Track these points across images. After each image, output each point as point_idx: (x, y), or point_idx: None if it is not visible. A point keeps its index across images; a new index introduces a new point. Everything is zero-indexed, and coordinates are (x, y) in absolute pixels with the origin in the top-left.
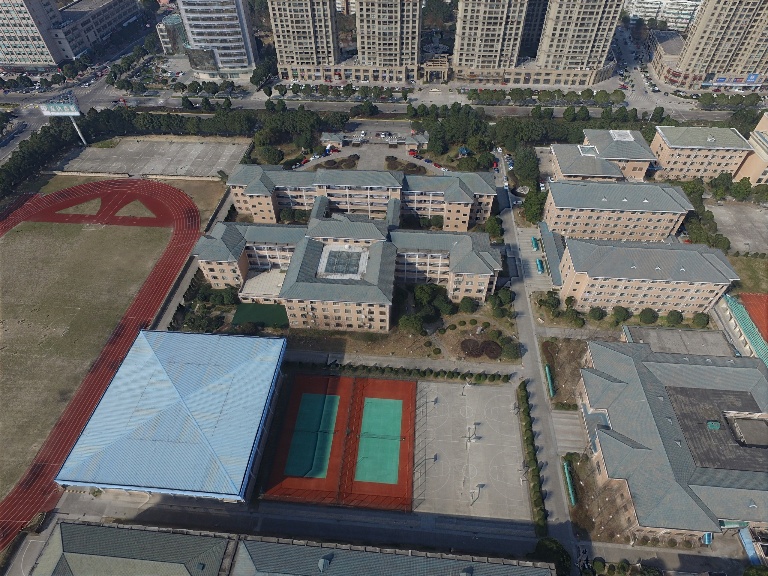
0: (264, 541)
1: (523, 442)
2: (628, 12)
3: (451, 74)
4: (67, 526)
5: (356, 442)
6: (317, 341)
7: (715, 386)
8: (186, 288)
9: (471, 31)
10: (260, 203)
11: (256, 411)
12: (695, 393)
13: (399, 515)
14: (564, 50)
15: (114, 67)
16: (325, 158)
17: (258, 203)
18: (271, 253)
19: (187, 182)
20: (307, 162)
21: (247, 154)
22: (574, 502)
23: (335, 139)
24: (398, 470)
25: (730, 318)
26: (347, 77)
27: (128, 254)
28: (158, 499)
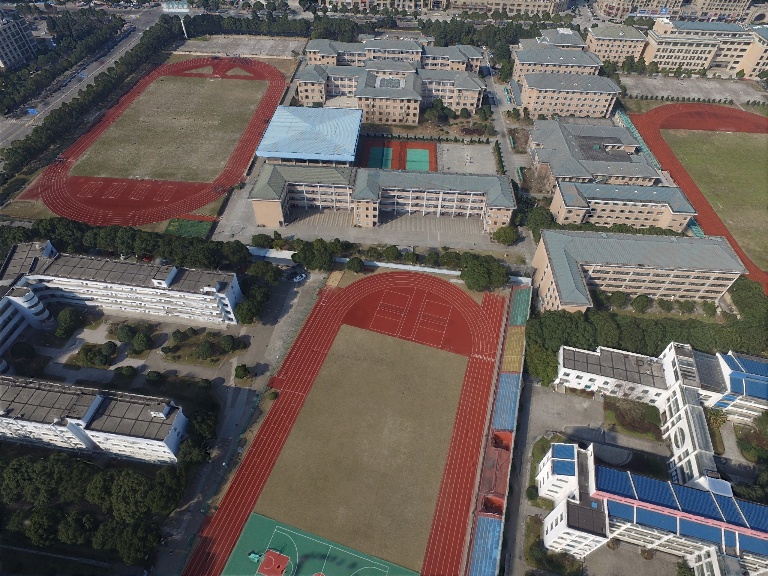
0: None
1: (497, 164)
2: None
3: (448, 4)
4: None
5: (405, 163)
6: (375, 128)
7: (601, 135)
8: None
9: None
10: (328, 63)
11: (354, 132)
12: (590, 138)
13: None
14: None
15: None
16: None
17: (327, 63)
18: (342, 83)
19: (269, 59)
20: None
21: None
22: (522, 181)
23: (369, 37)
24: None
25: (619, 122)
26: (370, 5)
27: (243, 92)
28: None
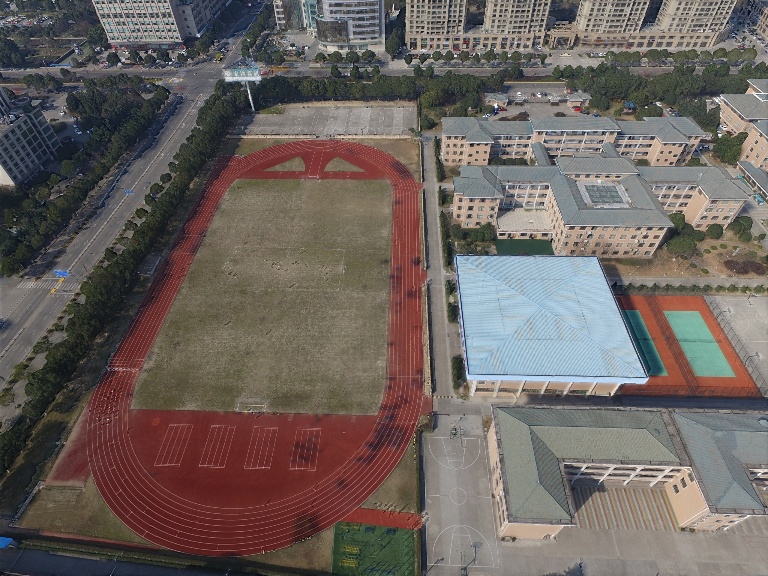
0: (693, 412)
1: None
2: None
3: (576, 40)
4: (506, 409)
5: (678, 346)
6: None
7: None
8: (435, 229)
9: None
10: (477, 152)
11: (614, 313)
12: None
13: (754, 400)
14: (690, 13)
15: (245, 41)
16: (496, 116)
17: (476, 152)
18: (521, 192)
19: (375, 141)
20: None
21: (424, 114)
22: None
23: (501, 98)
24: (730, 366)
25: None
26: (474, 46)
27: (360, 203)
28: (525, 399)
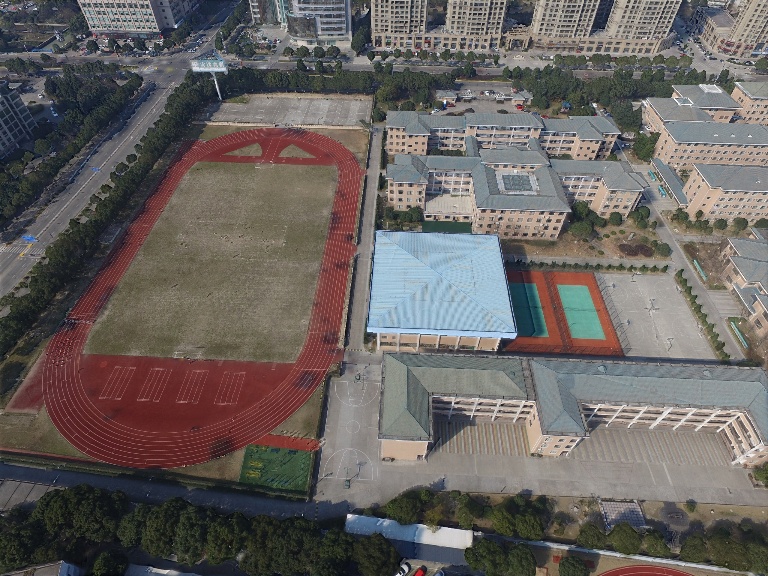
0: (548, 360)
1: (692, 311)
2: None
3: (530, 43)
4: (394, 354)
5: (562, 313)
6: None
7: None
8: (371, 211)
9: (554, 3)
10: (416, 143)
11: (501, 282)
12: None
13: (616, 358)
14: (635, 21)
15: (219, 34)
16: (444, 111)
17: (415, 143)
18: (447, 179)
19: (330, 130)
20: None
21: (377, 107)
22: None
23: (450, 95)
24: (603, 331)
25: None
26: (435, 45)
27: (307, 186)
28: None
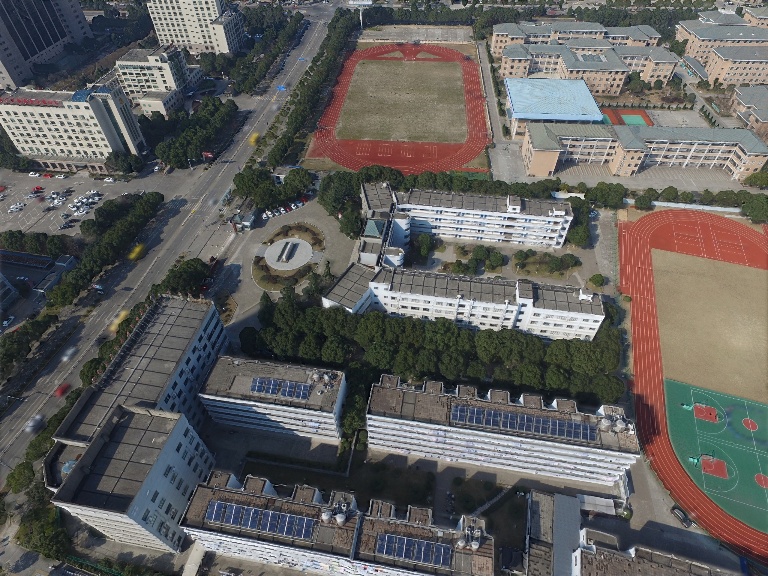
0: None
1: (710, 126)
2: None
3: None
4: None
5: None
6: None
7: None
8: (489, 83)
9: None
10: None
11: (590, 97)
12: None
13: None
14: None
15: None
16: None
17: None
18: (543, 60)
19: (447, 44)
20: None
21: None
22: None
23: (531, 24)
24: None
25: None
26: None
27: (442, 71)
28: None
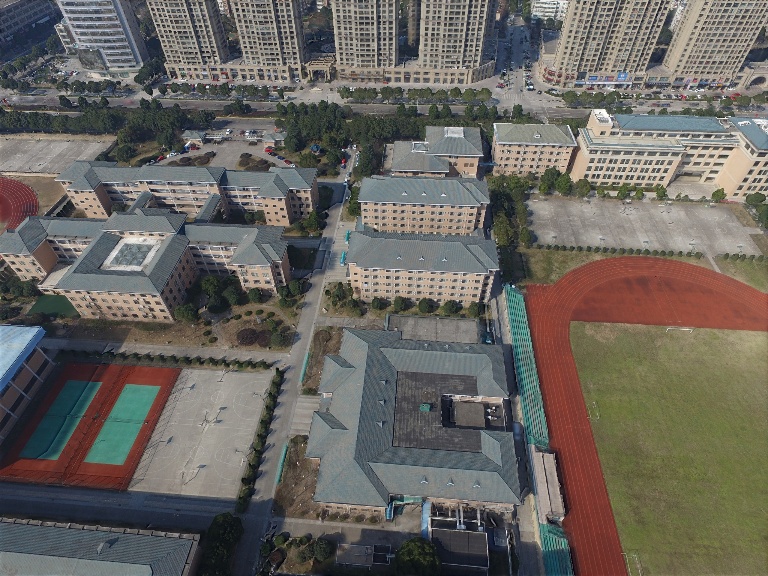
0: None
1: (259, 425)
2: (531, 12)
3: (335, 73)
4: None
5: (100, 426)
6: (102, 331)
7: (444, 371)
8: None
9: (346, 31)
10: (87, 198)
11: None
12: (424, 377)
13: (112, 494)
14: (439, 49)
15: (5, 67)
16: (182, 155)
17: (85, 198)
18: (74, 246)
19: (39, 179)
20: (163, 159)
21: None
22: (283, 481)
23: (195, 137)
24: (129, 452)
25: (505, 307)
26: (234, 76)
27: None
28: None
